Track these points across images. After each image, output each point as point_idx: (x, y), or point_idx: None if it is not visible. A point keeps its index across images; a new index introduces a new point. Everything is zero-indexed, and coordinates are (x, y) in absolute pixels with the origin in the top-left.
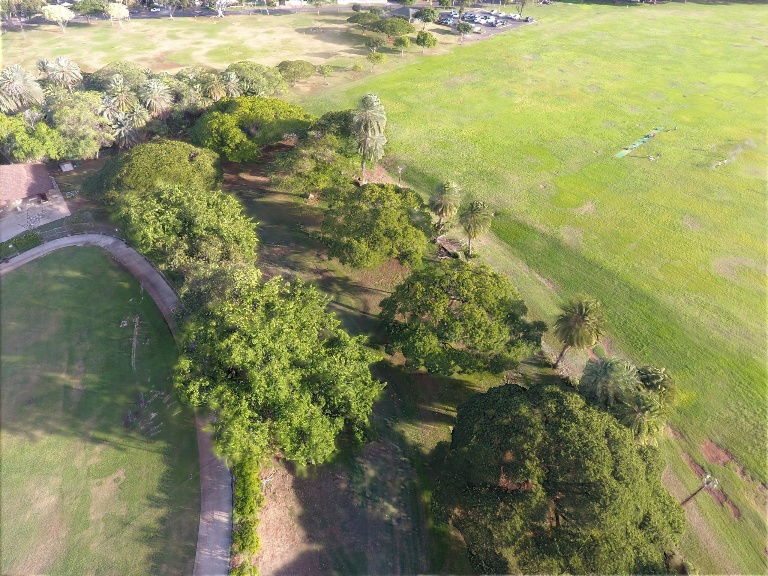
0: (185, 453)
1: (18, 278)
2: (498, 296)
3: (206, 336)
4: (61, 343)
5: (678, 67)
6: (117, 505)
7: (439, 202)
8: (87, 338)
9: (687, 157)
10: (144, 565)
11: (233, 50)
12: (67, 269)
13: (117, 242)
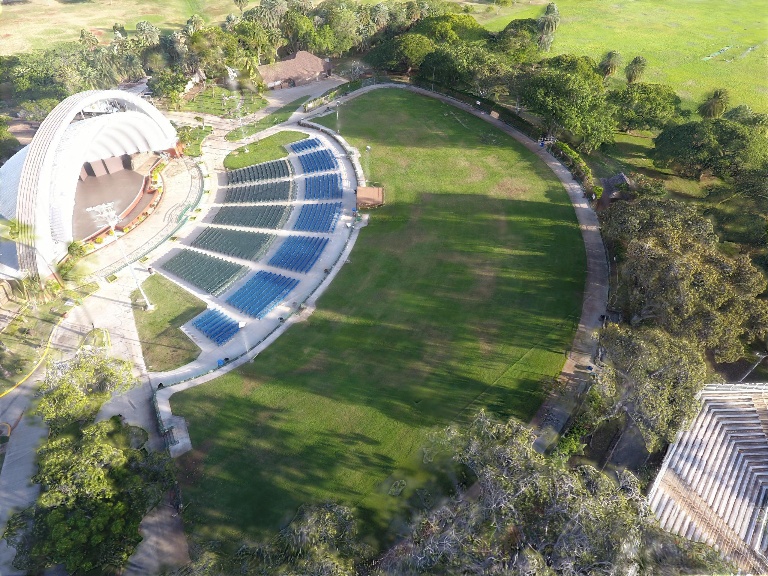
0: (522, 149)
1: (362, 101)
2: (667, 92)
3: (551, 78)
4: (416, 121)
5: (737, 13)
6: None
7: (607, 64)
8: (429, 120)
9: (753, 60)
10: (531, 174)
11: (379, 0)
12: (389, 96)
13: (409, 86)
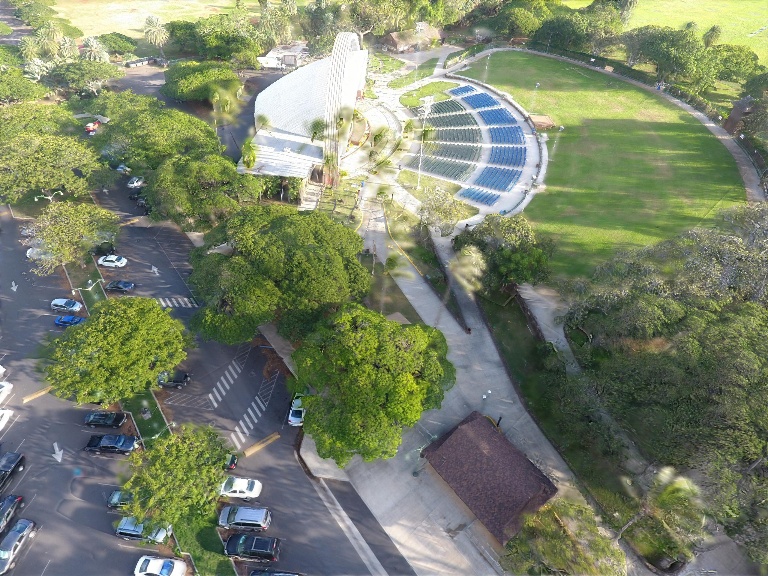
0: (644, 91)
1: None
2: (748, 50)
3: (672, 33)
4: None
5: (762, 1)
6: (632, 100)
7: None
8: None
9: None
10: None
11: None
12: None
13: (524, 49)
